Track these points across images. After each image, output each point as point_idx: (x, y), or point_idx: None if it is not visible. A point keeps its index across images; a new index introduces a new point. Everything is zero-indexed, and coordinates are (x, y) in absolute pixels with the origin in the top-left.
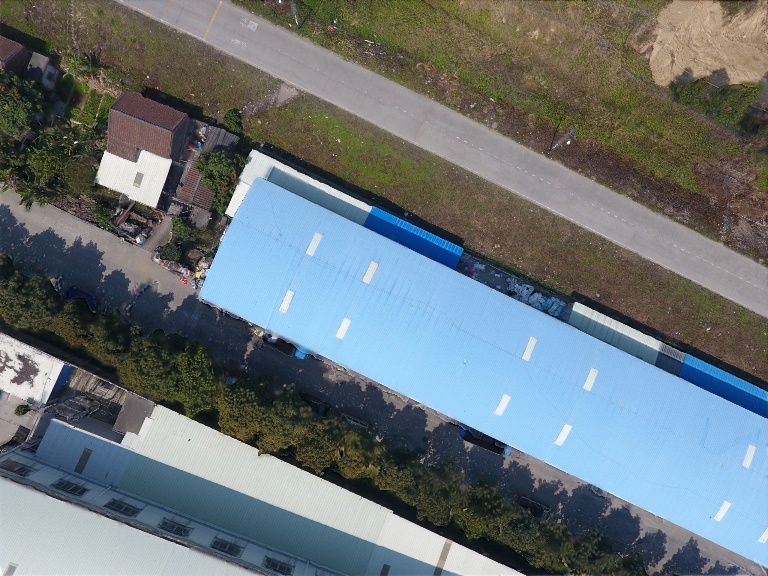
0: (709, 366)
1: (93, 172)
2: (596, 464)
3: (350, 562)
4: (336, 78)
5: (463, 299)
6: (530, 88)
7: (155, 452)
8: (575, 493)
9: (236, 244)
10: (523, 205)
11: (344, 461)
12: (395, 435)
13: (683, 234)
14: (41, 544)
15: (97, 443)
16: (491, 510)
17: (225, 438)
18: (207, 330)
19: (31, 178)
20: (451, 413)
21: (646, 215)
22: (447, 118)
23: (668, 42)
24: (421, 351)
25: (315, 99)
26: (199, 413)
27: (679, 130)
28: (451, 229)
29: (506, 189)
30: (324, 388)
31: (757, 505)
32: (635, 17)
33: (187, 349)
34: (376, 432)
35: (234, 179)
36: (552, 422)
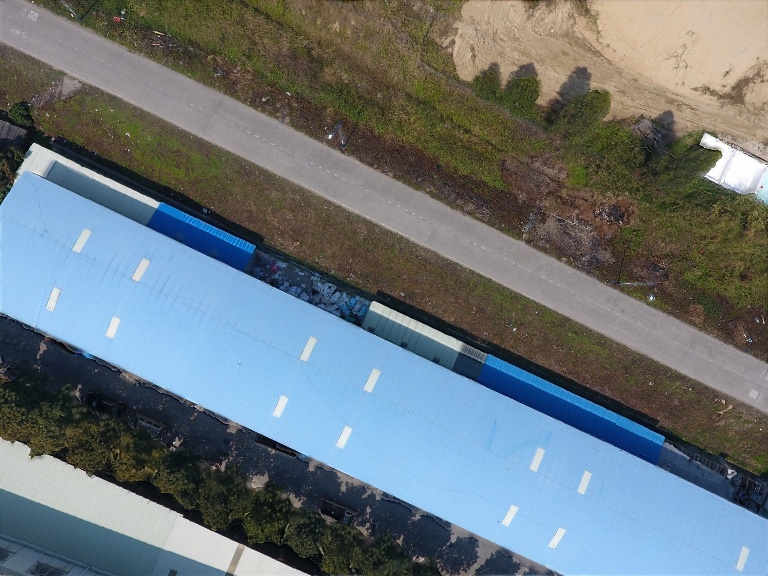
0: (512, 367)
1: None
2: (379, 467)
3: (134, 567)
4: (121, 70)
5: (240, 298)
6: (328, 82)
7: None
8: None
9: None
10: (316, 202)
11: (117, 464)
12: (196, 437)
13: (483, 232)
14: None
15: None
16: (271, 514)
17: None
18: None
19: None
20: (229, 415)
21: (445, 212)
22: (237, 112)
23: (468, 36)
24: (194, 351)
25: (99, 92)
26: None
27: (485, 126)
28: (250, 226)
29: (299, 185)
30: (121, 389)
31: (545, 509)
32: (437, 10)
33: None
34: (176, 434)
35: (9, 173)
36: (332, 424)
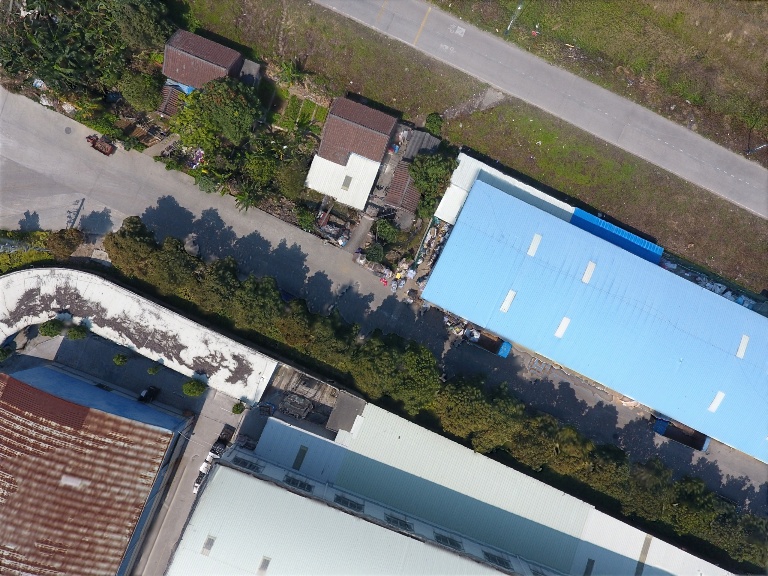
0: None
1: (303, 176)
2: None
3: (556, 557)
4: (541, 82)
5: (677, 298)
6: (725, 90)
7: (367, 449)
8: (762, 489)
9: (460, 245)
10: (723, 205)
11: (560, 457)
12: (587, 432)
13: None
14: (290, 538)
15: (312, 440)
16: (703, 505)
17: (433, 435)
18: (406, 330)
19: (249, 182)
20: (664, 410)
21: None
22: (648, 120)
23: None
24: (638, 349)
25: (521, 103)
26: (401, 411)
27: None
28: (645, 229)
29: (706, 189)
30: (518, 386)
31: None
32: None
33: (408, 348)
34: None
35: (447, 182)
36: (765, 418)
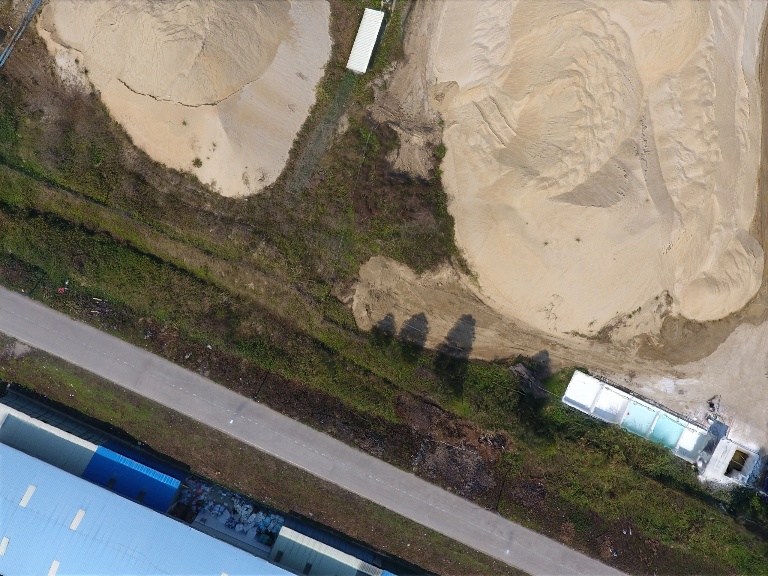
0: None
1: None
2: None
3: None
4: (64, 335)
5: (162, 540)
6: (243, 336)
7: None
8: None
9: None
10: (232, 444)
11: None
12: None
13: (378, 466)
14: None
15: None
16: None
17: None
18: None
19: None
20: None
21: (344, 450)
22: (164, 368)
23: (363, 297)
24: None
25: (45, 354)
26: None
27: (382, 368)
28: (178, 457)
29: (217, 430)
30: None
31: None
32: (338, 272)
33: None
34: None
35: None
36: None
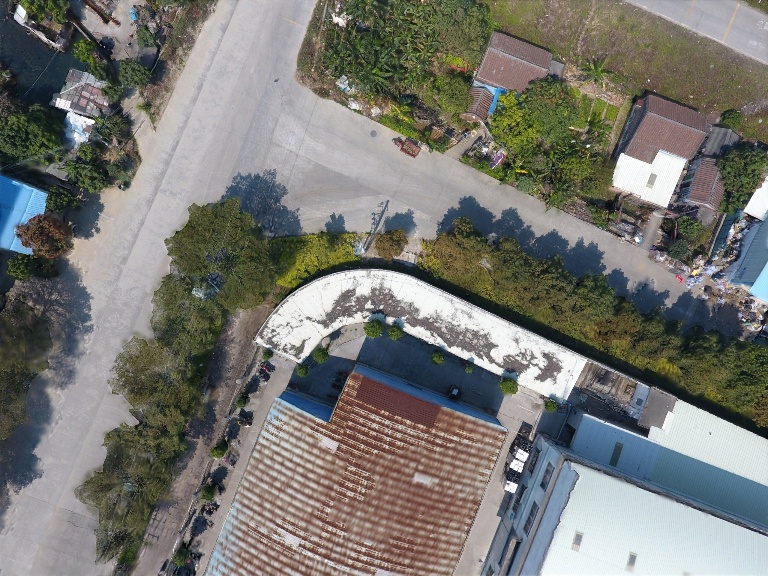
0: None
1: None
2: None
3: None
4: None
5: None
6: None
7: (680, 445)
8: None
9: None
10: None
11: None
12: None
13: None
14: (650, 534)
15: (627, 437)
16: None
17: (741, 431)
18: None
19: (563, 181)
20: None
21: None
22: None
23: None
24: None
25: None
26: (701, 407)
27: None
28: None
29: None
30: None
31: None
32: None
33: (734, 344)
34: None
35: (763, 177)
36: None
